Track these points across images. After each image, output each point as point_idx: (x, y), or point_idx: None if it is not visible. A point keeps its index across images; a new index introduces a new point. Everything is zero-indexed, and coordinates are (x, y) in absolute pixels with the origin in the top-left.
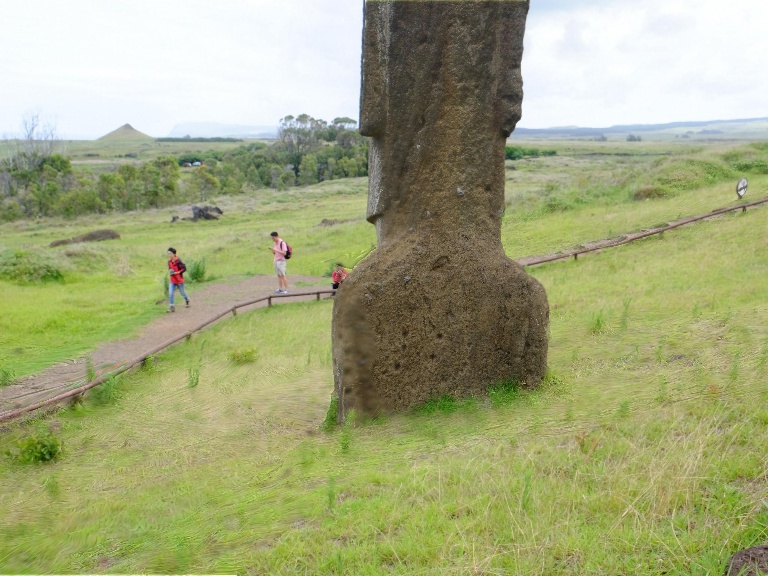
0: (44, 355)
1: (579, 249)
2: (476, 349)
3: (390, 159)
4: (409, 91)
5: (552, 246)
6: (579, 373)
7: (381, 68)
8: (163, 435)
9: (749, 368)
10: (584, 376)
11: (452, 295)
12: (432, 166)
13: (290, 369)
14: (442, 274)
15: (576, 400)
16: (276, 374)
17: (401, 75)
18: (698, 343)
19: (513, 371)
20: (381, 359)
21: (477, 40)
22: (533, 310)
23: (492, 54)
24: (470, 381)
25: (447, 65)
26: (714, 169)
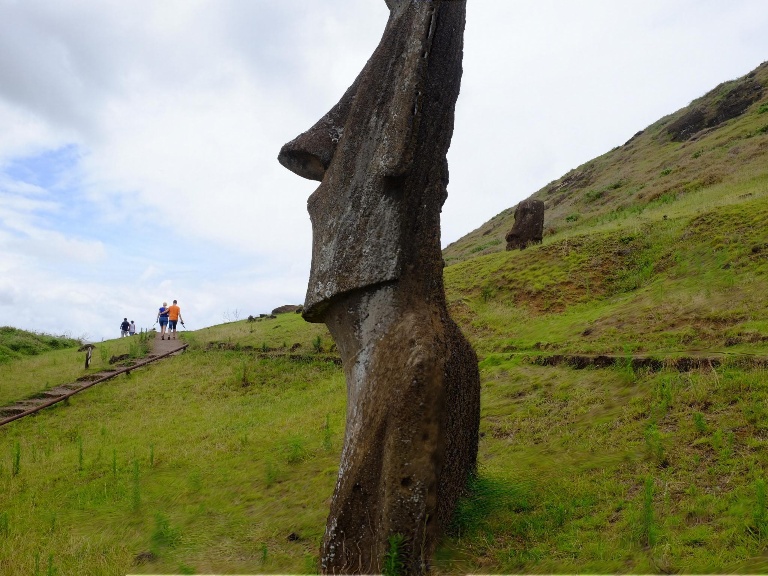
0: None
1: None
2: None
3: (405, 214)
4: (424, 144)
5: None
6: None
7: None
8: None
9: (600, 409)
10: None
11: None
12: (434, 231)
13: None
14: None
15: None
16: None
17: (420, 125)
18: None
19: None
20: None
21: None
22: None
23: None
24: None
25: None
26: None
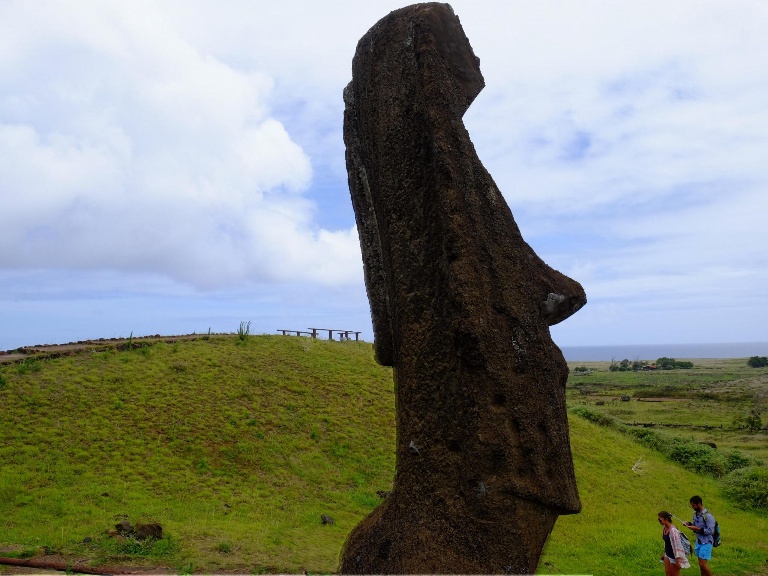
0: (544, 575)
1: None
2: None
3: None
4: None
5: None
6: None
7: (377, 286)
8: None
9: None
10: None
11: None
12: None
13: None
14: (384, 567)
15: None
16: None
17: None
18: None
19: None
20: None
21: (420, 232)
22: None
23: (442, 246)
24: None
25: (395, 273)
26: None
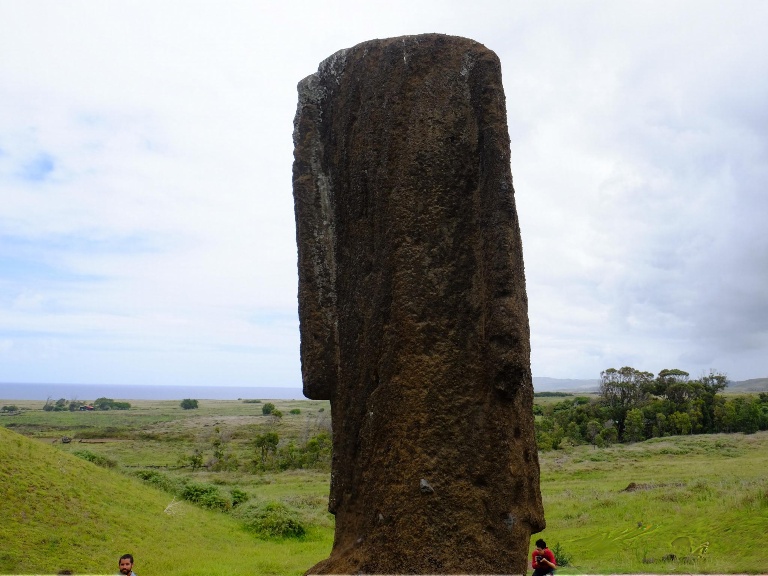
0: None
1: None
2: None
3: (343, 431)
4: (358, 337)
5: None
6: None
7: (324, 309)
8: None
9: None
10: None
11: None
12: (386, 444)
13: None
14: None
15: None
16: None
17: (349, 316)
18: None
19: None
20: None
21: (443, 262)
22: None
23: (471, 279)
24: None
25: (398, 299)
26: None
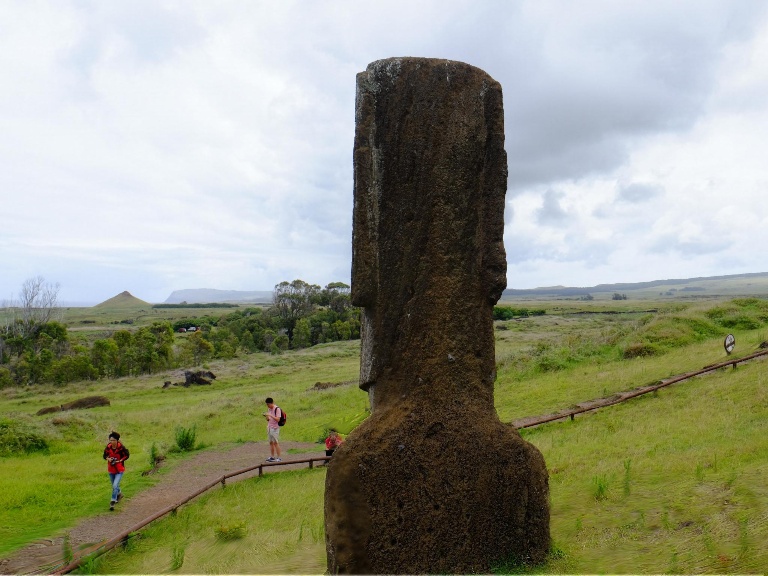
0: (21, 535)
1: (575, 409)
2: (475, 521)
3: (381, 328)
4: (398, 264)
5: (547, 406)
6: (585, 544)
7: (371, 244)
8: None
9: (760, 536)
10: (590, 547)
11: (448, 463)
12: (423, 334)
13: (281, 546)
14: (437, 441)
15: (584, 575)
16: (266, 552)
17: (390, 249)
18: (705, 508)
19: (515, 544)
20: (376, 534)
21: (460, 217)
22: (531, 477)
23: (475, 229)
24: (471, 556)
25: (433, 240)
26: (700, 326)
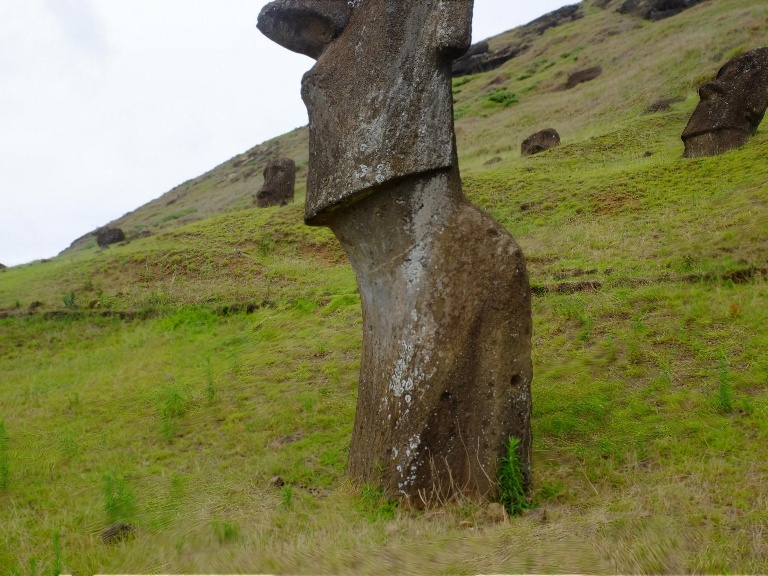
0: None
1: None
2: None
3: None
4: None
5: None
6: None
7: None
8: (760, 575)
9: None
10: None
11: None
12: None
13: None
14: None
15: None
16: None
17: None
18: None
19: None
20: None
21: None
22: None
23: None
24: None
25: None
26: None
